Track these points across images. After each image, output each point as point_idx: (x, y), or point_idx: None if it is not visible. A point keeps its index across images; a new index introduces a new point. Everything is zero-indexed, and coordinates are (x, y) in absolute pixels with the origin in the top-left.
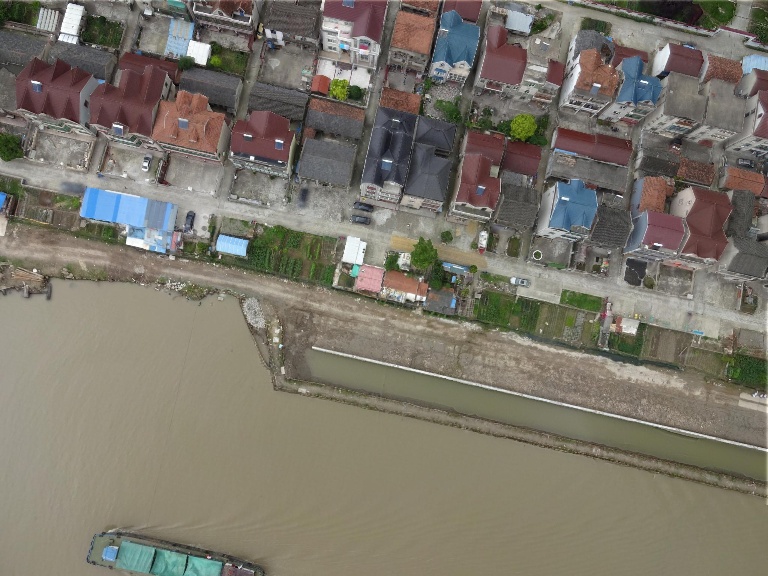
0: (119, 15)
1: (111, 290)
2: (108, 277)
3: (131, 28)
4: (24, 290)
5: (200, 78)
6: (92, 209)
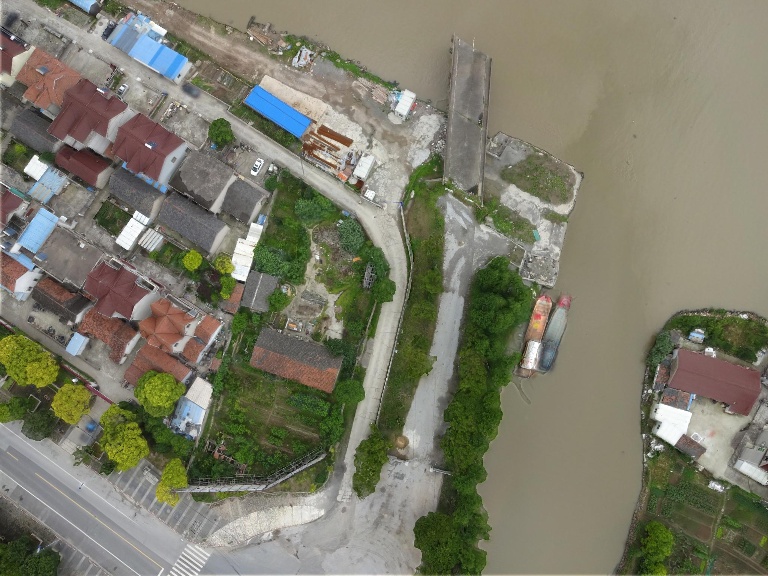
0: (96, 234)
1: (201, 7)
2: (197, 16)
3: (91, 218)
4: (267, 28)
5: (40, 139)
6: (177, 61)
